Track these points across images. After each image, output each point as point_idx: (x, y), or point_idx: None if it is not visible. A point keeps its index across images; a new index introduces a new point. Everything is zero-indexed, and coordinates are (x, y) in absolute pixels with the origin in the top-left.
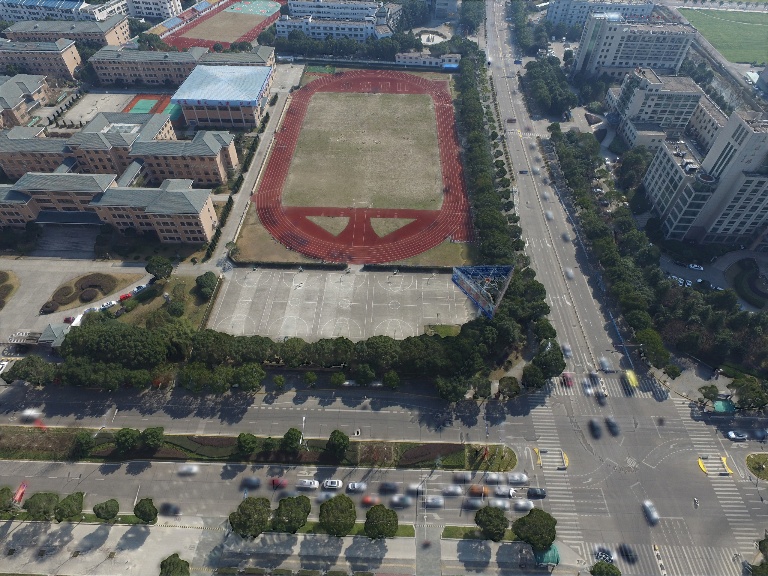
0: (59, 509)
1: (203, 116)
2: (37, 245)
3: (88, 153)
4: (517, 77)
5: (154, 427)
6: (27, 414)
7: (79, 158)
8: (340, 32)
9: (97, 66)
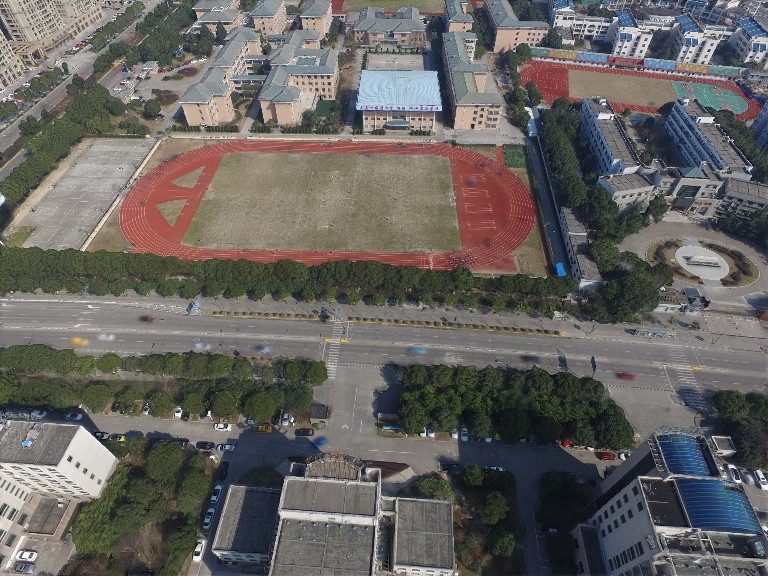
0: None
1: None
2: None
3: None
4: None
5: None
6: None
7: None
8: (601, 149)
9: None
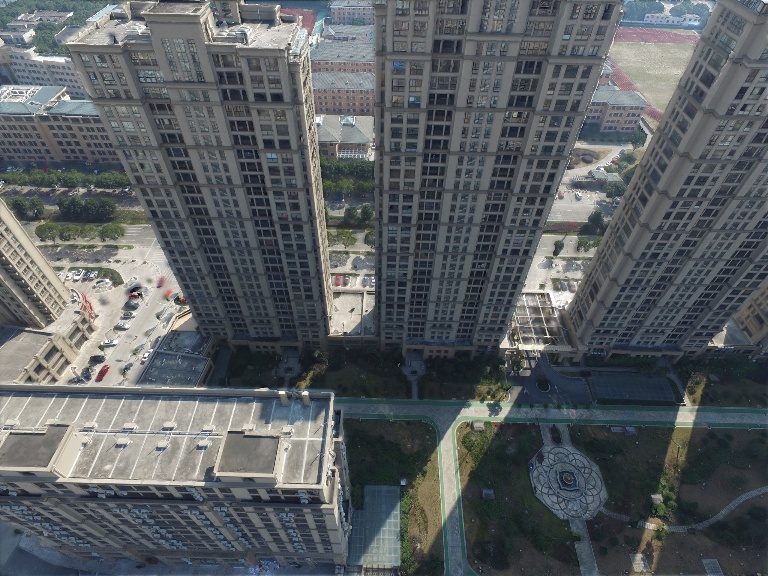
0: None
1: None
2: None
3: None
4: None
5: None
6: None
7: None
8: None
9: None
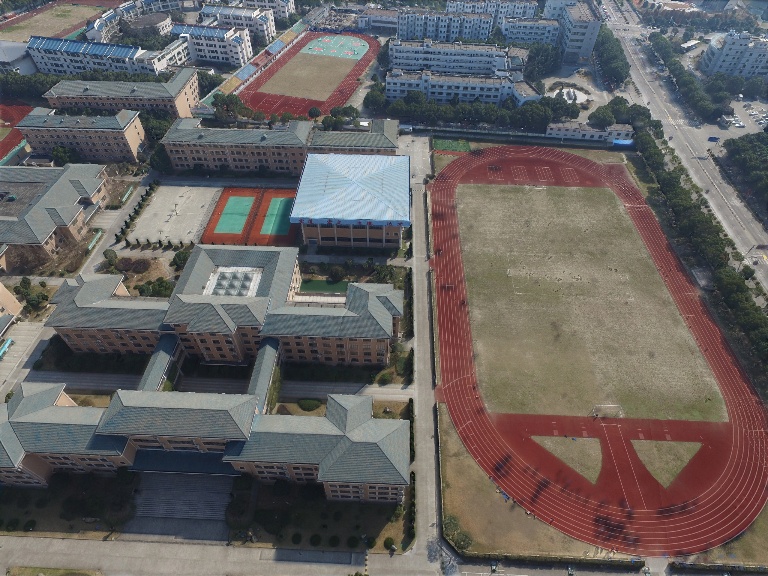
0: None
1: (329, 234)
2: (134, 508)
3: (199, 335)
4: (711, 158)
5: None
6: None
7: (182, 335)
8: (468, 92)
9: (171, 149)
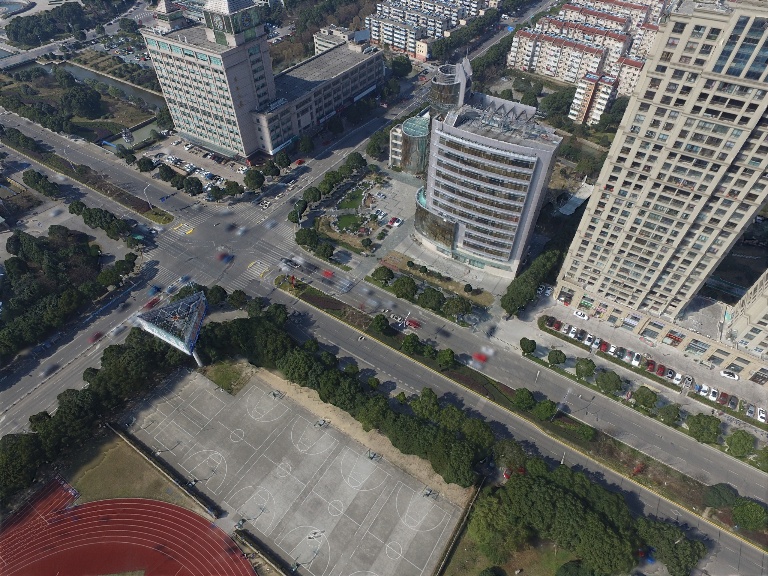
0: (591, 363)
1: None
2: None
3: None
4: None
5: (524, 426)
6: (661, 510)
7: None
8: None
9: None
